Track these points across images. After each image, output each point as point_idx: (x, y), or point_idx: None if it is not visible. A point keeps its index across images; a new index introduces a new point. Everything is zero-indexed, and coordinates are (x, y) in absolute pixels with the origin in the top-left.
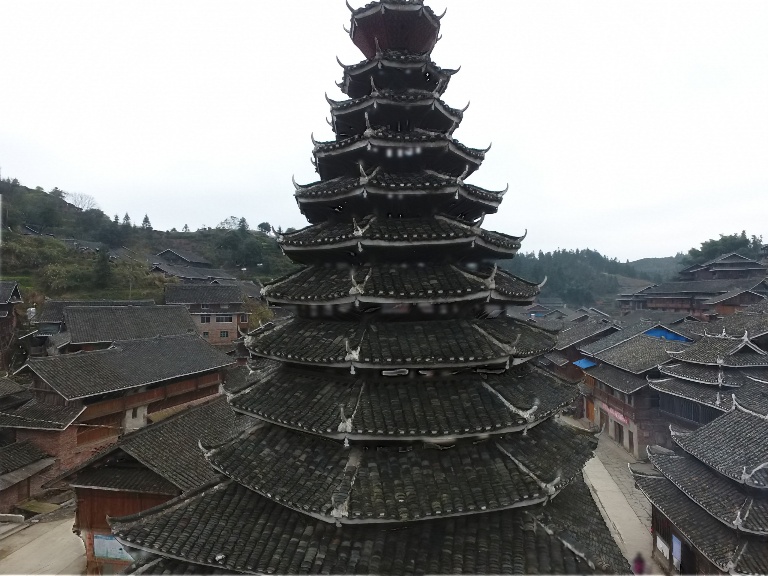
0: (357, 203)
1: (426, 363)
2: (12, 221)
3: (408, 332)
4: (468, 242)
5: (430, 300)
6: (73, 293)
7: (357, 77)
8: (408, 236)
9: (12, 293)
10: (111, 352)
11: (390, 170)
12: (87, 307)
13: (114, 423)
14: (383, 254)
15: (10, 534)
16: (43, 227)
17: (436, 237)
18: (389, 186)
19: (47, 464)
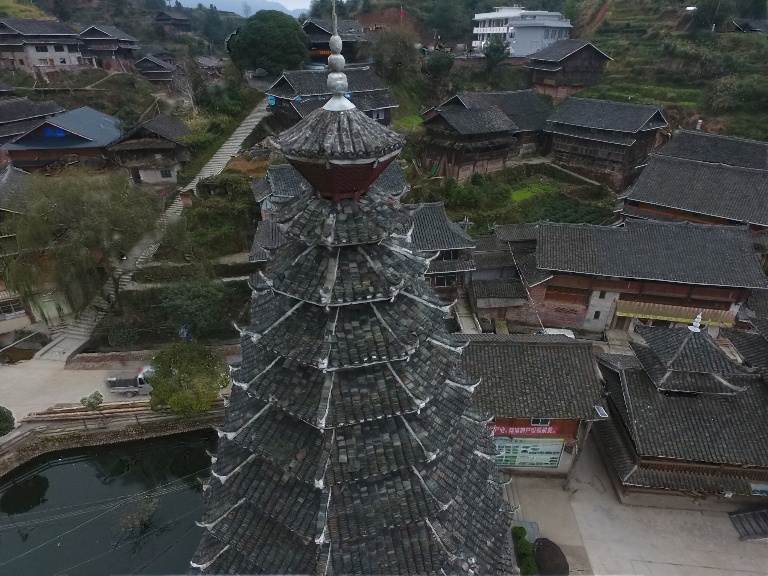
0: None
1: None
2: (719, 17)
3: None
4: None
5: None
6: (731, 115)
7: None
8: None
9: (648, 120)
10: (614, 230)
11: None
12: (673, 158)
13: (582, 295)
14: None
15: None
16: (751, 20)
17: None
18: None
19: (517, 304)
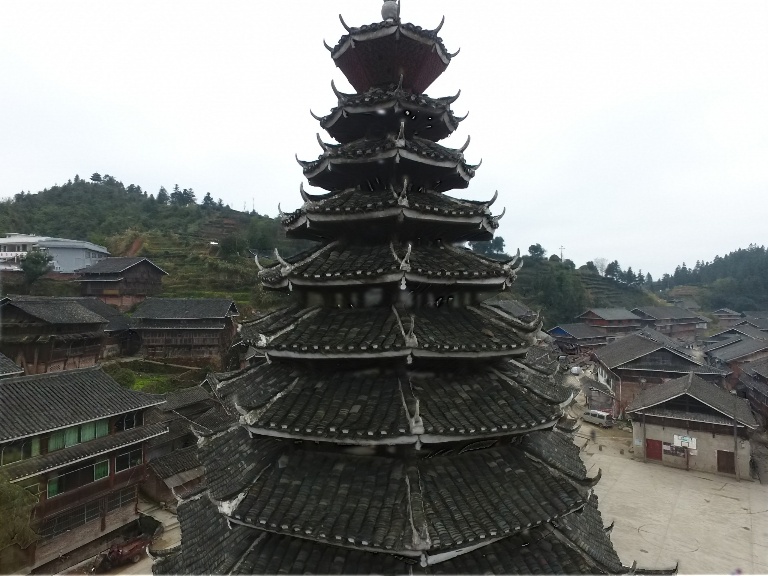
0: (298, 292)
1: (307, 536)
2: (240, 247)
3: (321, 474)
4: (401, 356)
5: (336, 440)
6: (277, 306)
7: (333, 129)
8: (319, 348)
9: (229, 309)
10: None
11: (349, 245)
12: None
13: None
14: (305, 364)
15: (175, 527)
16: (260, 251)
17: (354, 350)
18: (313, 277)
19: None
